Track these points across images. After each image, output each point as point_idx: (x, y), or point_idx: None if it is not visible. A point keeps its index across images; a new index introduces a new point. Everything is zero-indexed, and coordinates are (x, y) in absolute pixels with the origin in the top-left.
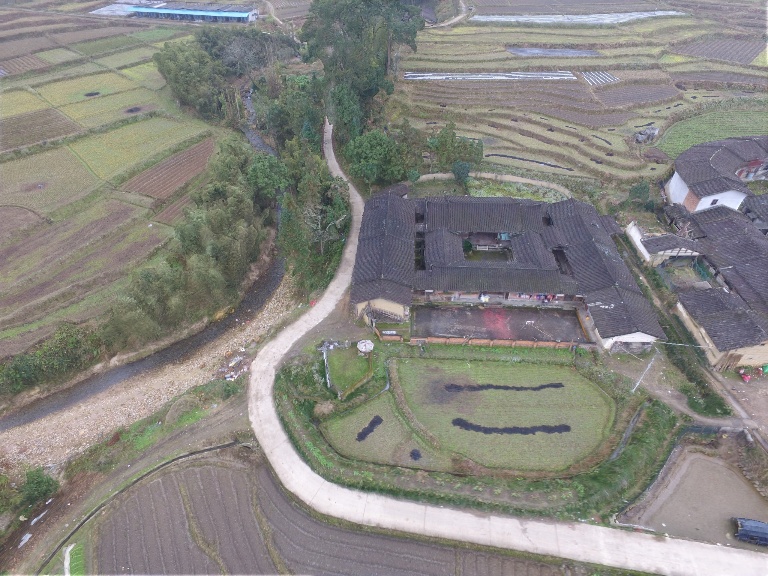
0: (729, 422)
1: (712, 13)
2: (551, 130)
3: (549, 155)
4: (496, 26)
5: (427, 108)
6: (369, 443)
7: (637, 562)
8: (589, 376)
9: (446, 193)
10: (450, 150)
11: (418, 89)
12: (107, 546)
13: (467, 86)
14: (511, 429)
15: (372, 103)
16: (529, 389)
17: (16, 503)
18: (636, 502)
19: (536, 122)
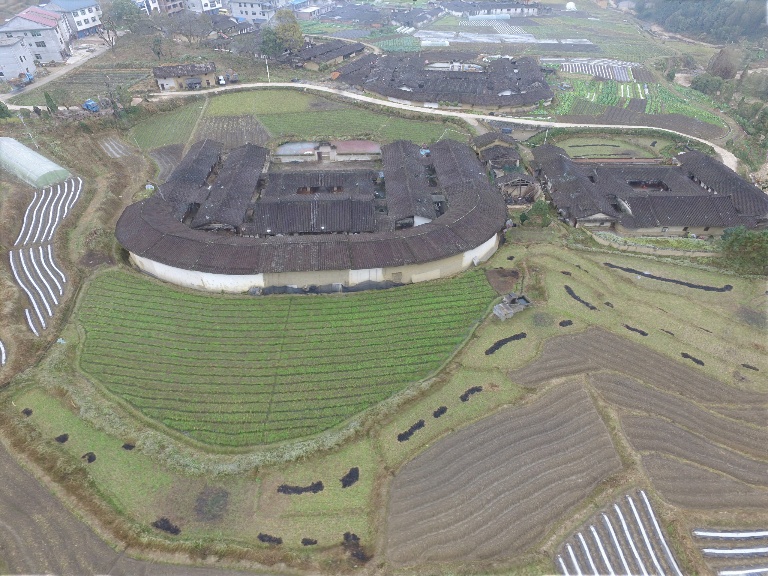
0: None
1: None
2: None
3: None
4: None
5: None
6: (650, 141)
7: (547, 122)
8: None
9: None
10: None
11: None
12: None
13: None
14: None
15: None
16: None
17: (763, 134)
18: None
19: None
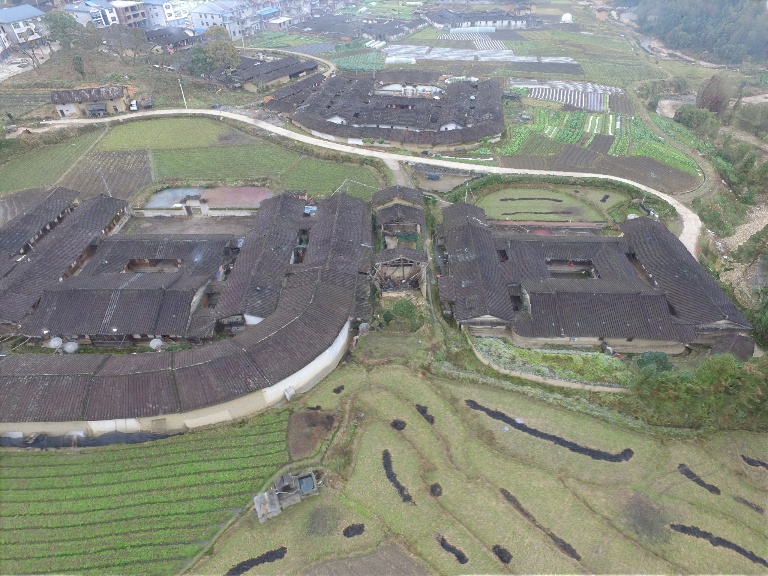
0: None
1: None
2: (501, 554)
3: None
4: None
5: None
6: (602, 194)
7: None
8: None
9: None
10: None
11: None
12: (686, 174)
13: None
14: (531, 199)
15: None
16: (522, 212)
17: None
18: None
19: None
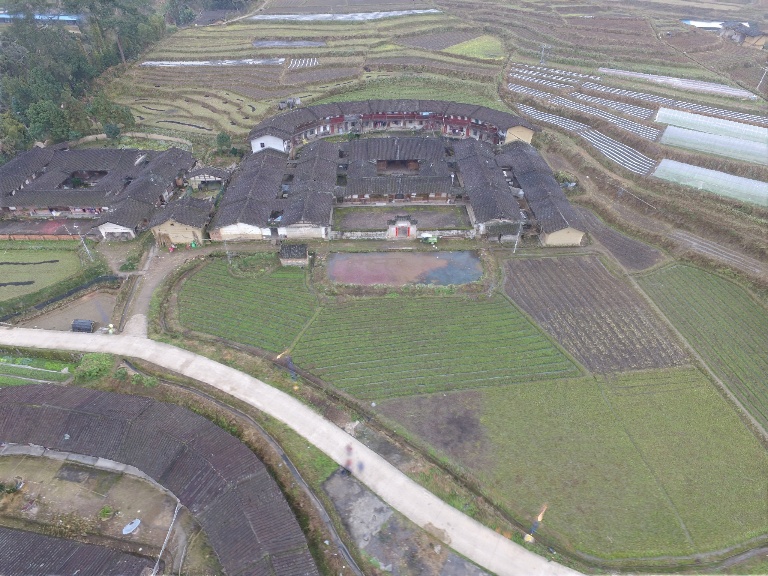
0: (131, 273)
1: (460, 10)
2: (225, 102)
3: (207, 120)
4: (266, 24)
5: (143, 88)
6: None
7: None
8: (79, 255)
9: (102, 148)
10: (105, 115)
11: (146, 74)
12: None
13: (185, 71)
14: None
15: (93, 84)
16: (31, 264)
17: None
18: (22, 314)
19: (219, 97)
